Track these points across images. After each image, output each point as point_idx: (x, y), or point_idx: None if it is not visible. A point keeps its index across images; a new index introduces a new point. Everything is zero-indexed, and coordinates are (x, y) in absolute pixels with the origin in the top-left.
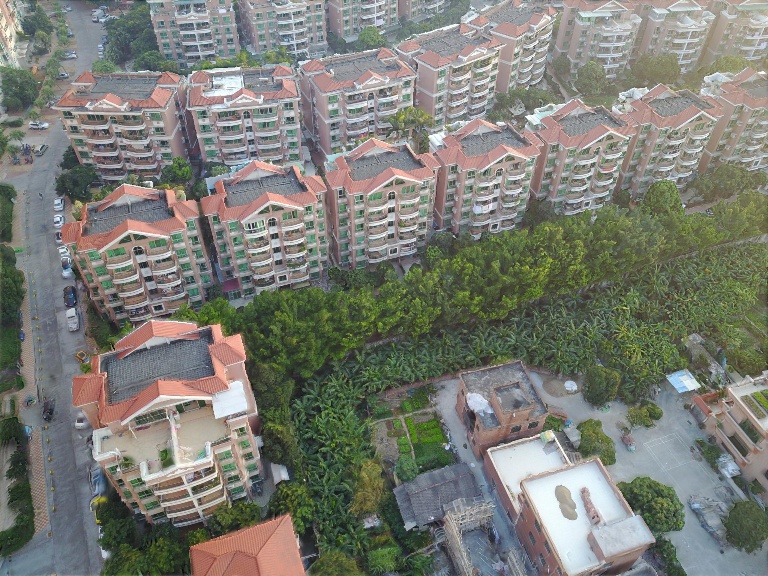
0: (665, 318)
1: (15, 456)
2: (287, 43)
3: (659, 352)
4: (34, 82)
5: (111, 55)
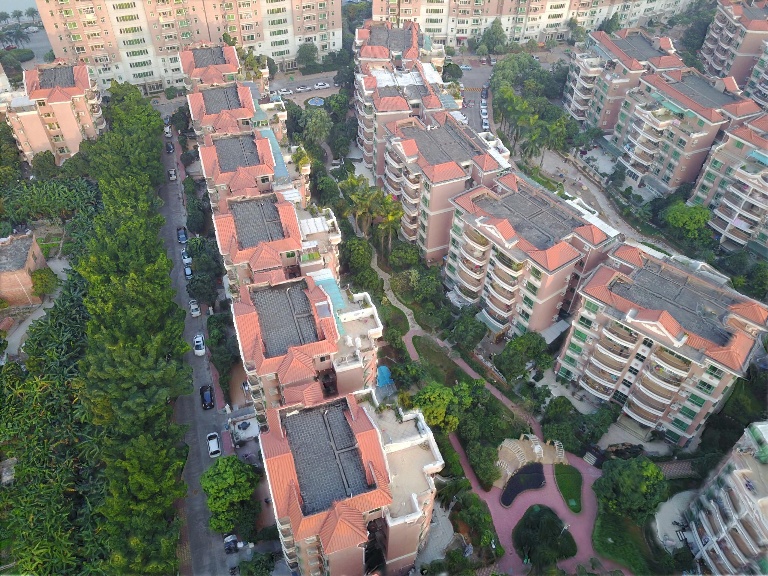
0: (44, 438)
1: (107, 97)
2: (628, 151)
3: (3, 413)
4: (500, 43)
5: (559, 64)
